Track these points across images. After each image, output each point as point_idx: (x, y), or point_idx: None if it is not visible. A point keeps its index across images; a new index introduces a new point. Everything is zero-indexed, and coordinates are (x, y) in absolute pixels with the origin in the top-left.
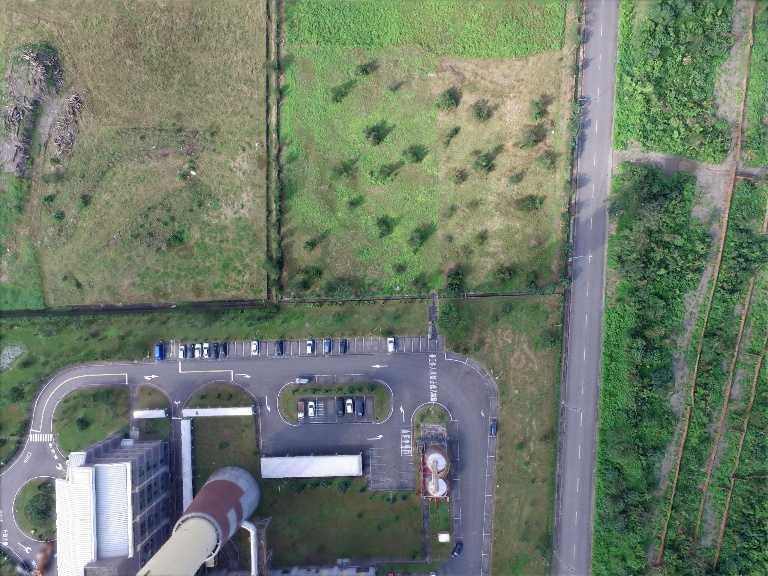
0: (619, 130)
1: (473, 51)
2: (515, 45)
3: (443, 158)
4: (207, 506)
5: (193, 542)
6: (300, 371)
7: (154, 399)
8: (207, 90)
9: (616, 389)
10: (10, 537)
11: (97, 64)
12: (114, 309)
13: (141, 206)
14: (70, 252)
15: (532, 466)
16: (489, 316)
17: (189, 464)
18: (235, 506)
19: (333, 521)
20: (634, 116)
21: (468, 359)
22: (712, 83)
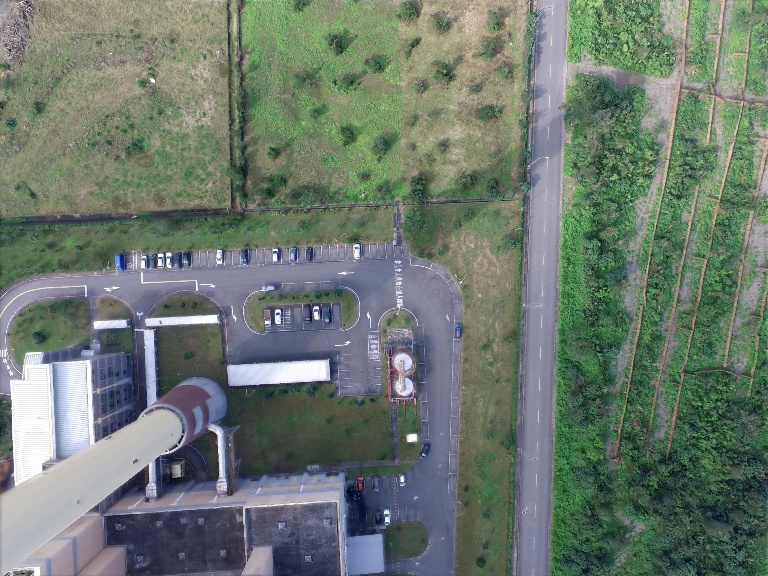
0: (573, 42)
1: None
2: None
3: (405, 68)
4: (172, 400)
5: (157, 424)
6: (266, 279)
7: (115, 311)
8: None
9: (574, 291)
10: None
11: None
12: (71, 220)
13: (98, 114)
14: (23, 161)
15: (496, 367)
16: (452, 222)
17: (153, 375)
18: (201, 405)
19: (302, 428)
20: (586, 29)
21: (433, 264)
22: (658, 1)
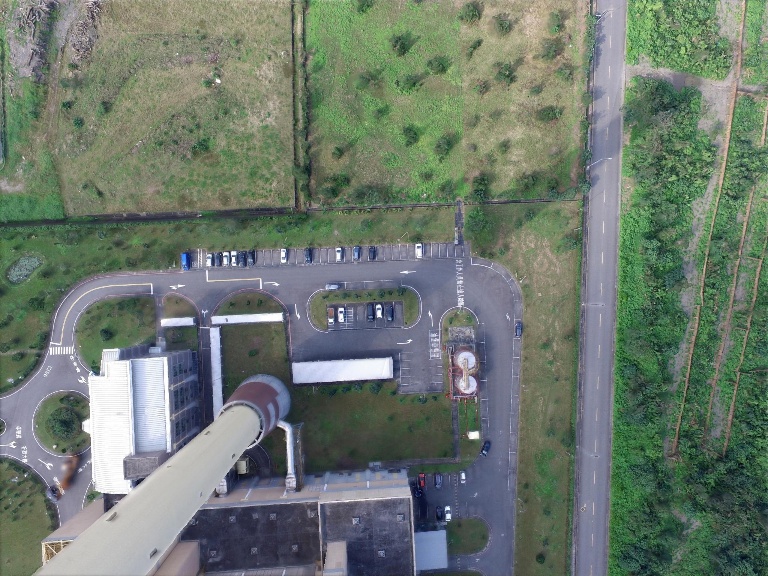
0: (632, 45)
1: None
2: None
3: (467, 69)
4: (248, 397)
5: (242, 420)
6: (329, 278)
7: (181, 308)
8: None
9: (632, 290)
10: (30, 454)
11: None
12: (137, 219)
13: (164, 114)
14: (90, 160)
15: (555, 365)
16: (513, 222)
17: (219, 372)
18: (273, 402)
19: (364, 425)
20: (645, 32)
21: (493, 264)
22: (714, 4)
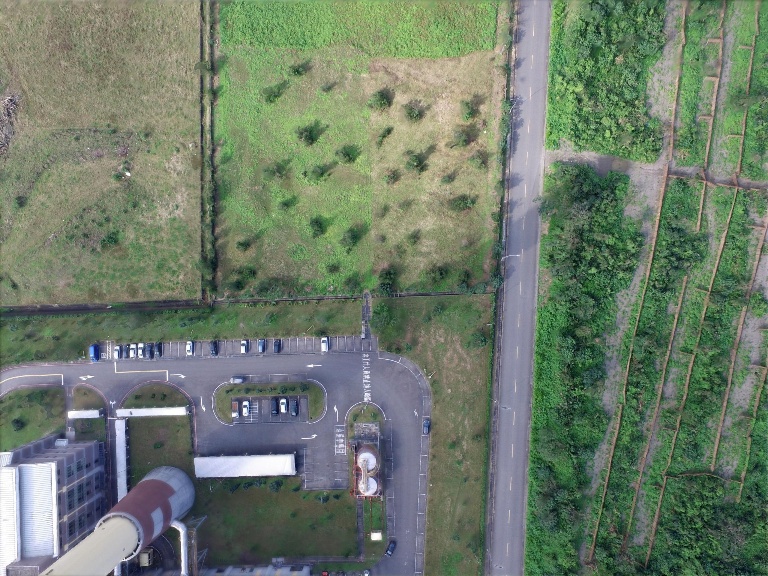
0: (551, 130)
1: (405, 51)
2: (447, 45)
3: (376, 158)
4: (130, 505)
5: (108, 541)
6: (235, 371)
7: (90, 399)
8: (141, 91)
9: (548, 388)
10: None
11: (32, 66)
12: (50, 310)
13: (76, 207)
14: (6, 253)
15: (465, 465)
16: (422, 315)
17: (124, 464)
18: (162, 505)
19: (267, 520)
20: (566, 116)
21: (401, 358)
22: (645, 82)
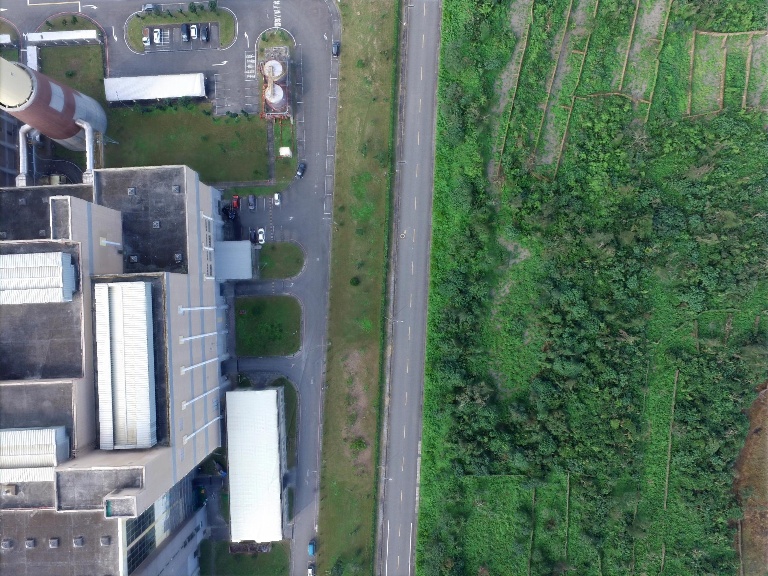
0: None
1: None
2: None
3: None
4: None
5: None
6: (146, 0)
7: (2, 31)
8: None
9: (456, 9)
10: None
11: None
12: None
13: None
14: None
15: (374, 86)
16: None
17: None
18: (64, 89)
19: (179, 146)
20: None
21: None
22: None
